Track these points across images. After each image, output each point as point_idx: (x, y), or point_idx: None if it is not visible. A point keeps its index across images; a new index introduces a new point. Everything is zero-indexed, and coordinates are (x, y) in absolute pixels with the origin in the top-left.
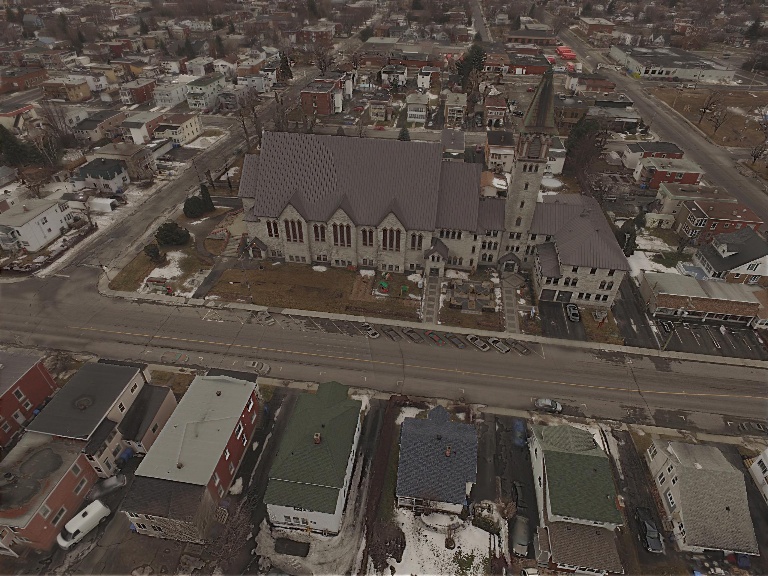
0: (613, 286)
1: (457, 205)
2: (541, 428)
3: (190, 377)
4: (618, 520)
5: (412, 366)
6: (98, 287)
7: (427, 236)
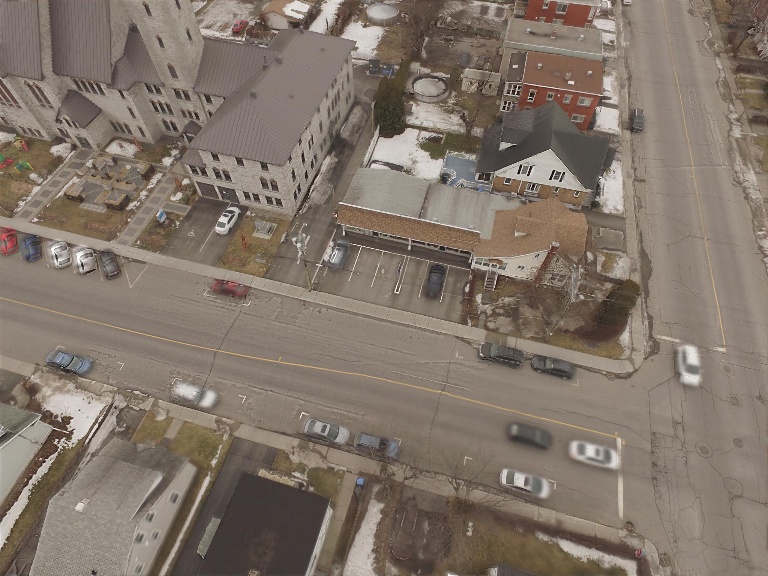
0: (278, 186)
1: (81, 38)
2: None
3: None
4: None
5: None
6: None
7: (45, 87)
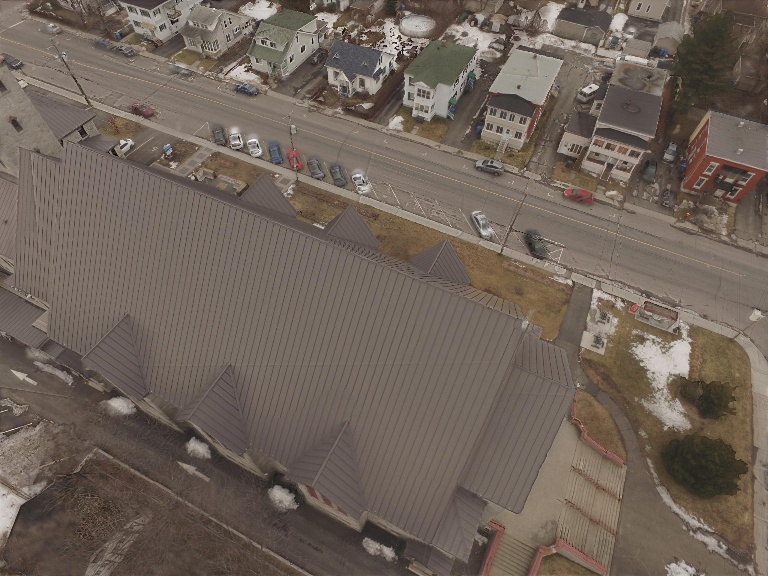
0: None
1: None
2: (278, 58)
3: (555, 177)
4: (286, 9)
5: (336, 140)
6: (763, 355)
7: None
